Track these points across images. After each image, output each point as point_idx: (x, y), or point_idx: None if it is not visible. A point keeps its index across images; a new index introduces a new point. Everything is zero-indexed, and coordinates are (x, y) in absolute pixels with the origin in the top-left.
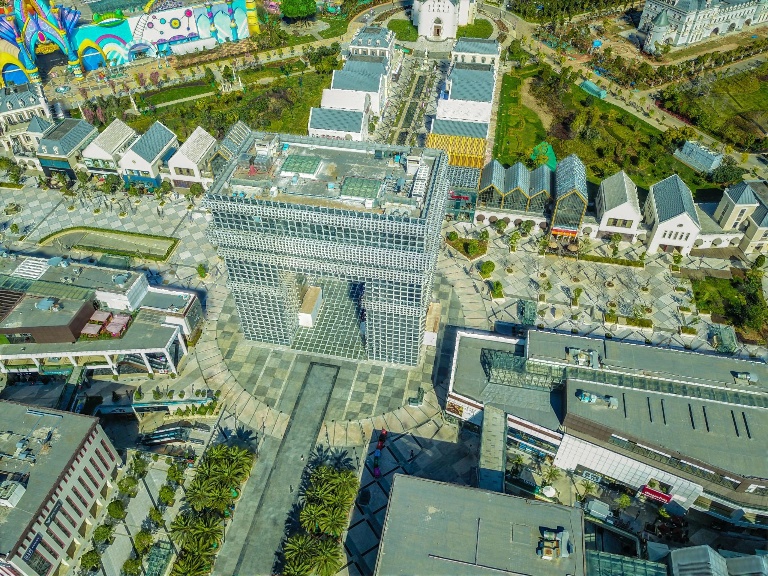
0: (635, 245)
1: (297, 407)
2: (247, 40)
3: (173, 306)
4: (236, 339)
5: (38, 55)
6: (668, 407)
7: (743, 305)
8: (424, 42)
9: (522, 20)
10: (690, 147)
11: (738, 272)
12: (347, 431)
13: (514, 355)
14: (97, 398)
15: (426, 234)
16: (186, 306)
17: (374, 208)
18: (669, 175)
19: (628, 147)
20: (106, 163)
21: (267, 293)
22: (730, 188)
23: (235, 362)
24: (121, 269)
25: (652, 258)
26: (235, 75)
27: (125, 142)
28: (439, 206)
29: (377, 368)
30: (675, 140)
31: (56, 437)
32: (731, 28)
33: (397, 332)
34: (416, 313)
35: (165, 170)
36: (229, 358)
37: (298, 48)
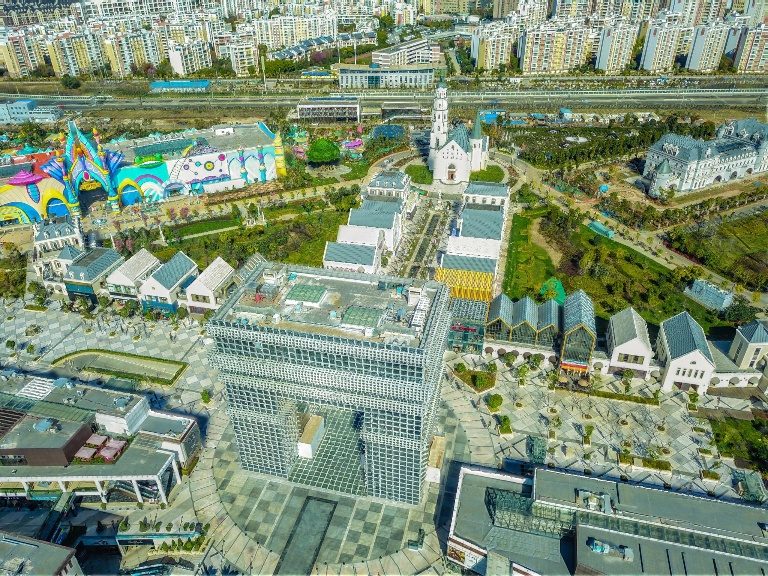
0: (649, 382)
1: (288, 546)
2: (274, 181)
3: (171, 431)
4: (233, 468)
5: (82, 191)
6: (690, 562)
7: None
8: (439, 185)
9: (532, 167)
10: (700, 285)
11: (760, 413)
12: (340, 575)
13: (521, 496)
14: (81, 528)
15: (424, 364)
16: (184, 432)
17: (373, 337)
18: (680, 312)
19: (637, 284)
20: (128, 289)
21: (265, 421)
22: (743, 326)
23: (229, 493)
24: (126, 392)
25: (667, 396)
26: (260, 211)
27: (148, 270)
28: (441, 337)
29: (376, 505)
30: (684, 278)
31: (27, 570)
32: (733, 176)
33: (397, 466)
34: (416, 446)
35: (183, 297)
36: (223, 489)
37: (321, 189)
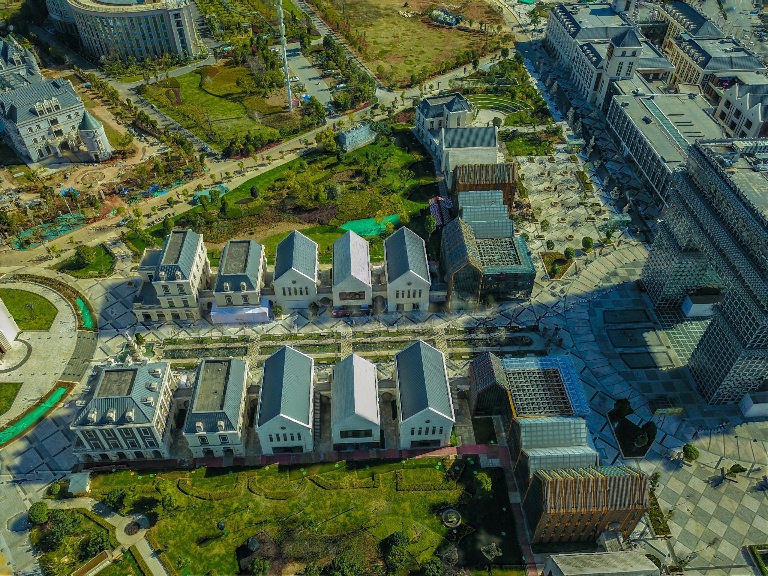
0: None
1: None
2: None
3: None
4: None
5: None
6: None
7: (529, 139)
8: (25, 371)
9: None
10: (351, 136)
11: None
12: None
13: None
14: None
15: None
16: None
17: None
18: None
19: (337, 175)
20: None
21: None
22: (429, 117)
23: None
24: None
25: None
26: None
27: None
28: None
29: None
30: None
31: None
32: None
33: None
34: None
35: None
36: None
37: None
